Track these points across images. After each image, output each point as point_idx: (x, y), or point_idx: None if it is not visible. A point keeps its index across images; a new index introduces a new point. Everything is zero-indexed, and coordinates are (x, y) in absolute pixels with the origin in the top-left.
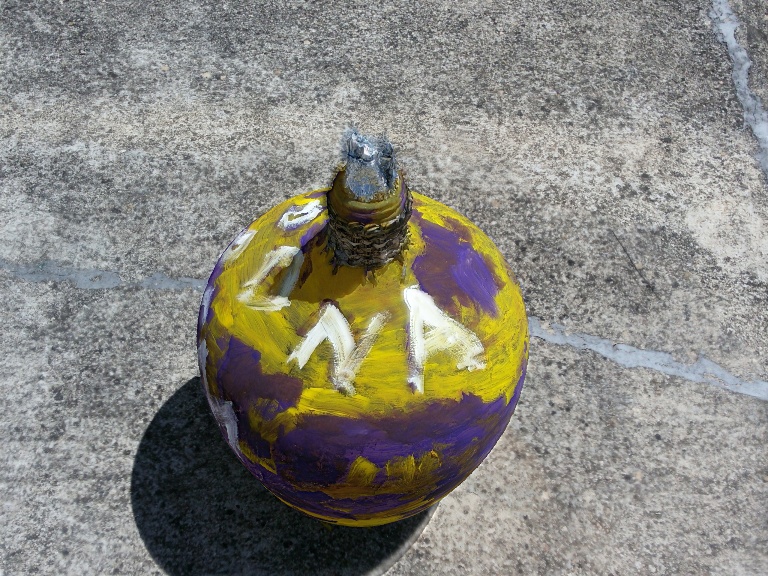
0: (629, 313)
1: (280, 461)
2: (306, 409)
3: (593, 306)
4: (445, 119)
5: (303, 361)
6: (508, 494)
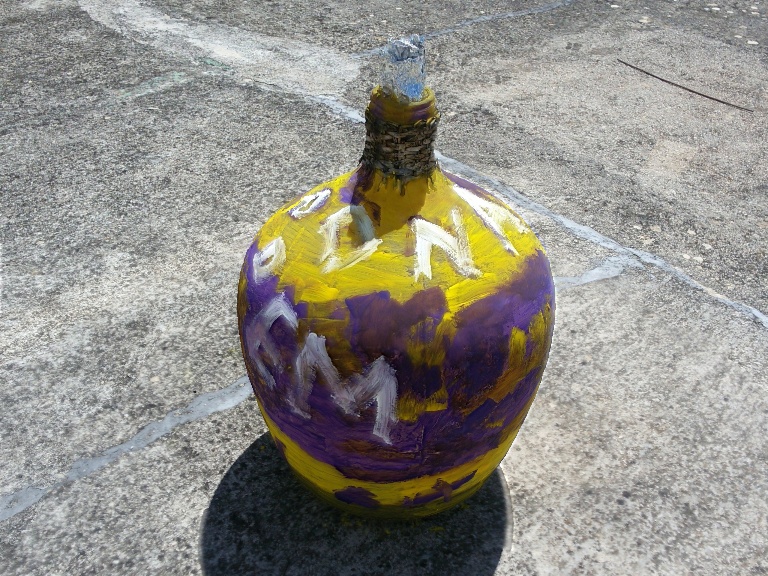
0: None
1: (452, 381)
2: (457, 307)
3: None
4: (219, 239)
5: (428, 271)
6: (530, 420)
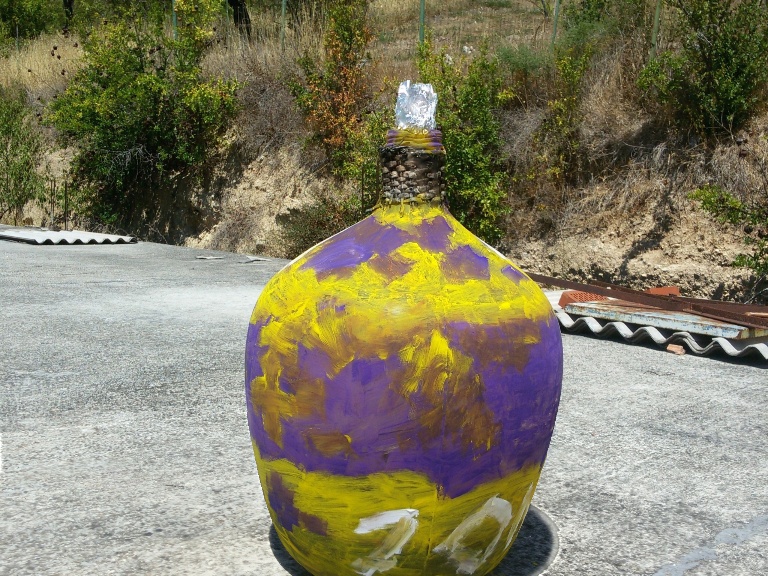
0: None
1: None
2: None
3: None
4: None
5: None
6: None
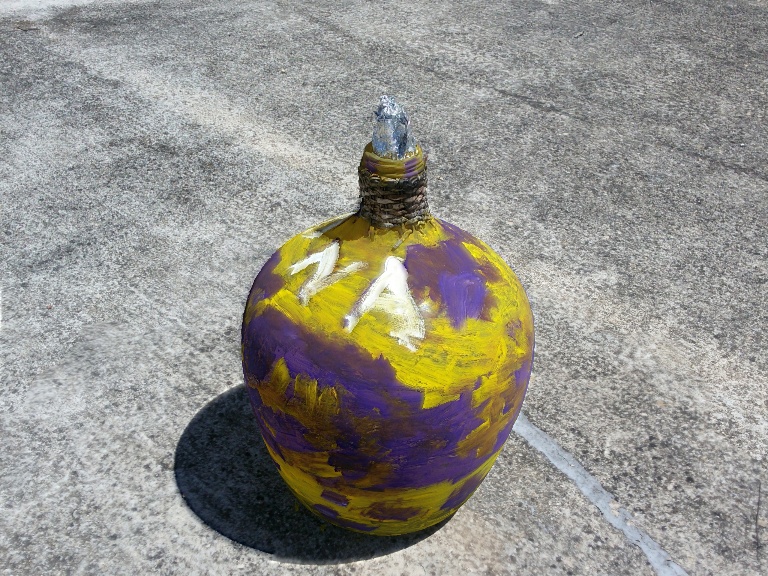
0: (711, 548)
1: (245, 345)
2: (274, 303)
3: (678, 521)
4: (675, 330)
5: (296, 271)
6: None
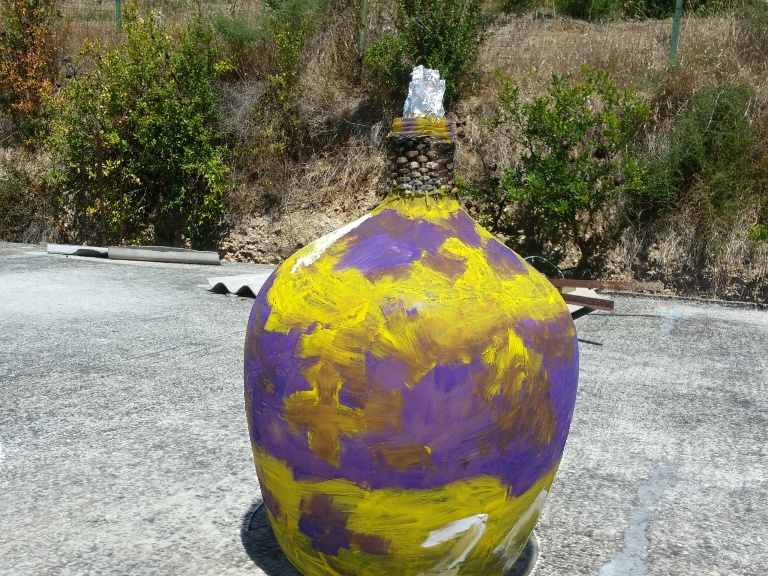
0: None
1: None
2: None
3: None
4: None
5: None
6: None
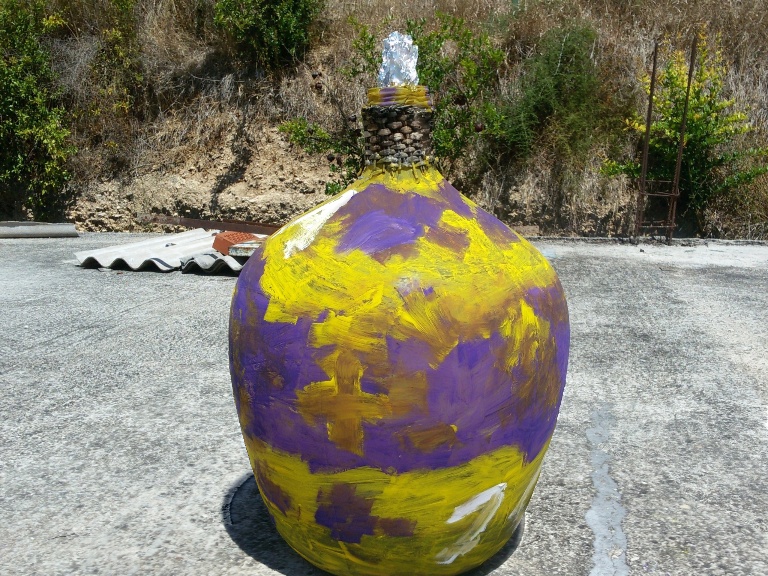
0: None
1: None
2: None
3: None
4: None
5: None
6: None
